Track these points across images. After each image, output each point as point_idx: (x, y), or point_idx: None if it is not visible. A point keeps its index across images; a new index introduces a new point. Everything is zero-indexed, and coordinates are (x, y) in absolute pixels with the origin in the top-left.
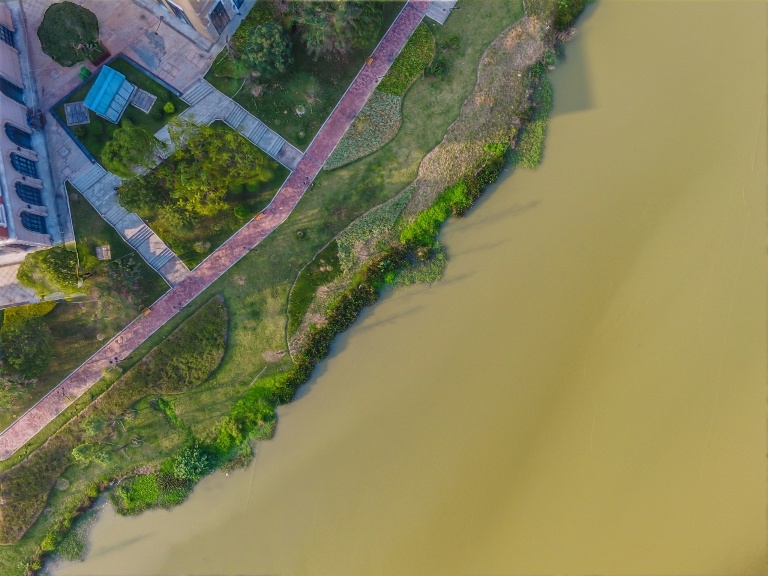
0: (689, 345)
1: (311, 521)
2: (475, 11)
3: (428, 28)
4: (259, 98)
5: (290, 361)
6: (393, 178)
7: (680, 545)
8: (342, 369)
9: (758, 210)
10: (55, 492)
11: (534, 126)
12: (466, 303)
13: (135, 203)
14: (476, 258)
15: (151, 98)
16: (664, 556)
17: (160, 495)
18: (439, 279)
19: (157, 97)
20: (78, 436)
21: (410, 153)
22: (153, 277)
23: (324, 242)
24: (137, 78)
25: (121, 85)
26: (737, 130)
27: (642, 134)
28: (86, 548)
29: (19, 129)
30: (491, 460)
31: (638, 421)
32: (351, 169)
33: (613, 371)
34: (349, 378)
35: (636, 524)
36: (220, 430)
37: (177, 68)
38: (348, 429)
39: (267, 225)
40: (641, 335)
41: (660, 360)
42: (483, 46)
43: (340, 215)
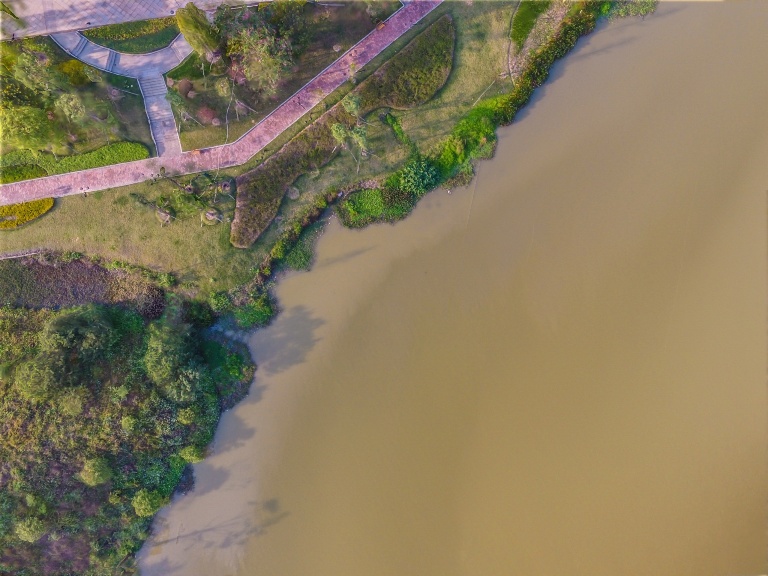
0: None
1: (529, 239)
2: None
3: None
4: None
5: (511, 84)
6: None
7: None
8: (559, 95)
9: None
10: (286, 200)
11: None
12: (678, 35)
13: None
14: None
15: None
16: None
17: (385, 209)
18: (652, 12)
19: None
20: (312, 143)
21: None
22: None
23: None
24: None
25: None
26: None
27: None
28: (312, 258)
29: None
30: (703, 185)
31: None
32: None
33: None
34: (566, 103)
35: None
36: (444, 148)
37: None
38: (565, 152)
39: None
40: None
41: None
42: None
43: None
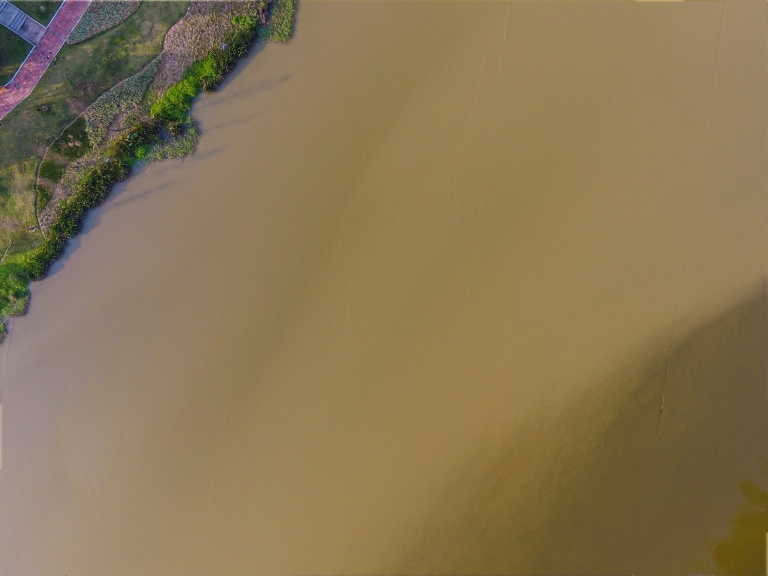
0: (444, 215)
1: (66, 396)
2: None
3: None
4: None
5: (41, 237)
6: (138, 51)
7: (438, 414)
8: (95, 245)
9: (511, 79)
10: None
11: (285, 0)
12: (219, 177)
13: None
14: (229, 132)
15: None
16: (422, 426)
17: None
18: (191, 154)
19: None
20: None
21: (153, 26)
22: None
23: (71, 117)
24: None
25: None
26: (490, 0)
27: (394, 7)
28: None
29: None
30: (246, 333)
31: (394, 292)
32: (94, 43)
33: (370, 243)
34: (102, 254)
35: (393, 394)
36: None
37: None
38: (102, 304)
39: (11, 100)
40: (396, 206)
41: (415, 230)
42: None
43: (86, 90)
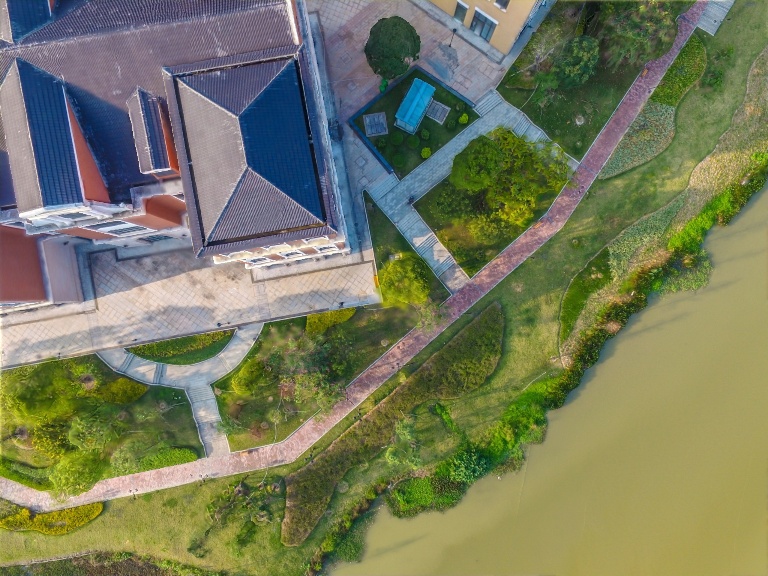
0: None
1: (581, 524)
2: (745, 22)
3: (699, 39)
4: (544, 109)
5: (561, 367)
6: (665, 187)
7: None
8: (610, 375)
9: None
10: (336, 494)
11: None
12: (731, 310)
13: (455, 213)
14: (740, 265)
15: (445, 109)
16: None
17: (434, 498)
18: (704, 286)
19: (451, 108)
20: (361, 440)
21: (683, 162)
22: (435, 284)
23: (596, 250)
24: None
25: None
26: None
27: None
28: (363, 549)
29: None
30: (756, 464)
31: None
32: (625, 178)
33: None
34: (617, 383)
35: None
36: (493, 434)
37: (470, 80)
38: (616, 434)
39: (544, 233)
40: None
41: None
42: (752, 57)
43: (613, 223)
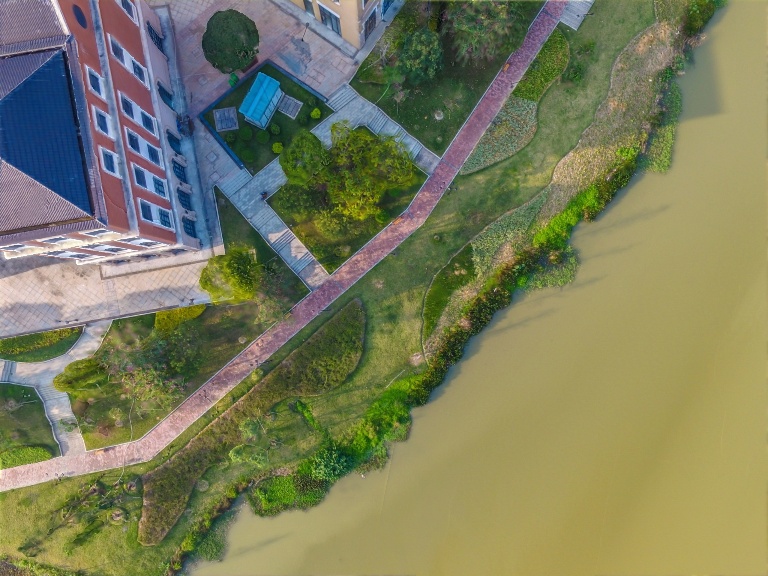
0: None
1: (445, 522)
2: (608, 17)
3: (562, 34)
4: (401, 104)
5: (425, 364)
6: (528, 182)
7: None
8: (475, 372)
9: None
10: (195, 493)
11: (664, 131)
12: (597, 306)
13: (295, 208)
14: (607, 262)
15: (297, 104)
16: None
17: (297, 496)
18: (570, 282)
19: (303, 103)
20: (220, 438)
21: (545, 158)
22: (293, 281)
23: (459, 246)
24: (285, 84)
25: (275, 91)
26: None
27: None
28: (224, 548)
29: (173, 135)
30: (622, 462)
31: (767, 423)
32: (487, 174)
33: (742, 374)
34: (482, 380)
35: (766, 525)
36: (356, 432)
37: (323, 74)
38: (481, 431)
39: (405, 229)
40: None
41: None
42: (616, 52)
43: (475, 219)
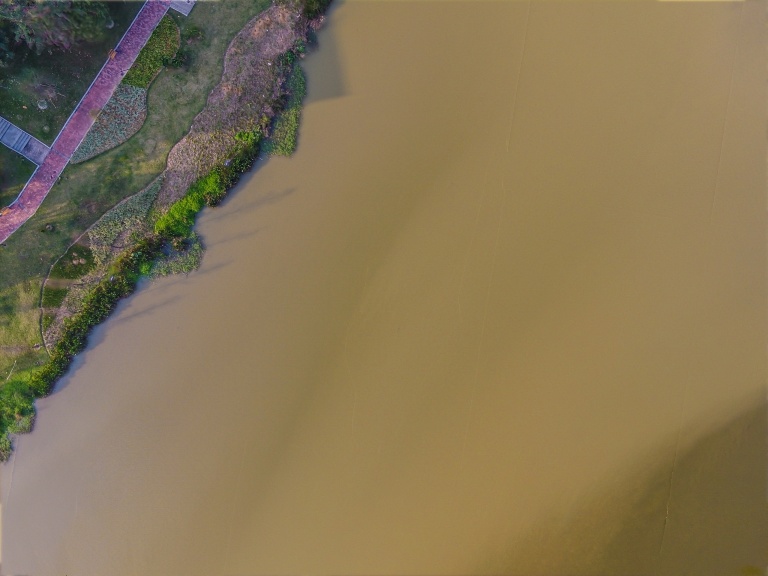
0: (448, 327)
1: (72, 513)
2: (220, 2)
3: (173, 20)
4: None
5: (46, 354)
6: (141, 170)
7: (443, 527)
8: (100, 361)
9: (514, 191)
10: None
11: (288, 114)
12: (223, 292)
13: None
14: (233, 247)
15: None
16: (428, 539)
17: None
18: (196, 269)
19: None
20: None
21: (157, 144)
22: None
23: (75, 235)
24: None
25: None
26: (492, 112)
27: (397, 119)
28: None
29: None
30: (252, 448)
31: (399, 405)
32: (98, 162)
33: (374, 356)
34: (108, 370)
35: (398, 507)
36: None
37: None
38: (108, 421)
39: (15, 220)
40: (400, 319)
41: (419, 343)
42: (229, 36)
43: (90, 208)
